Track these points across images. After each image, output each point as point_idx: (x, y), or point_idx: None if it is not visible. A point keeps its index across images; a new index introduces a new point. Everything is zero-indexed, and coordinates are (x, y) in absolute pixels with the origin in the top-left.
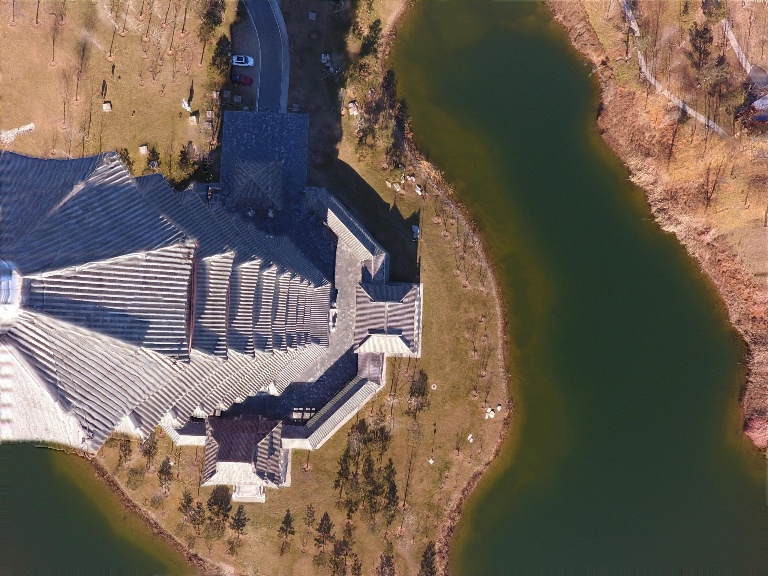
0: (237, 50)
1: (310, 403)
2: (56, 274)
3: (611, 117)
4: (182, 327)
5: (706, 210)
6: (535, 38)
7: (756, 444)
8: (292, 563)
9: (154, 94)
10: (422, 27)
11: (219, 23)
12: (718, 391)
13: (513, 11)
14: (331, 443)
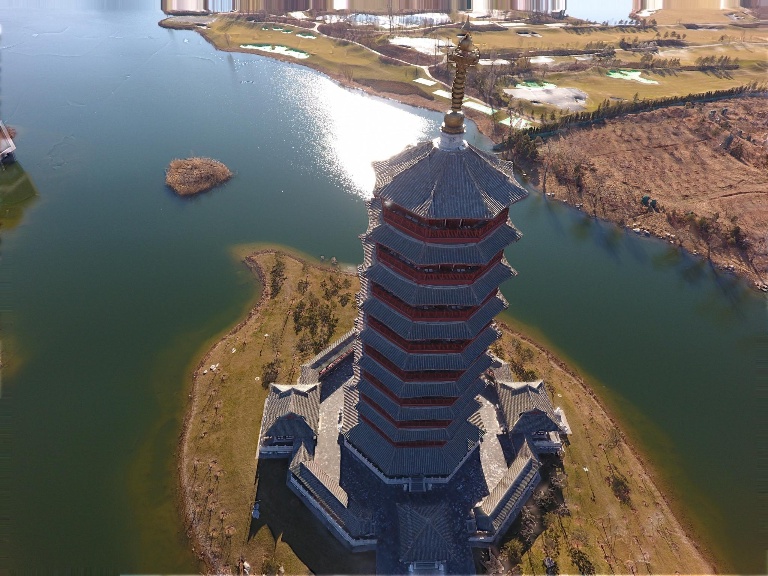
0: None
1: None
2: None
3: None
4: None
5: None
6: None
7: None
8: None
9: None
10: None
11: None
12: None
13: None
14: None
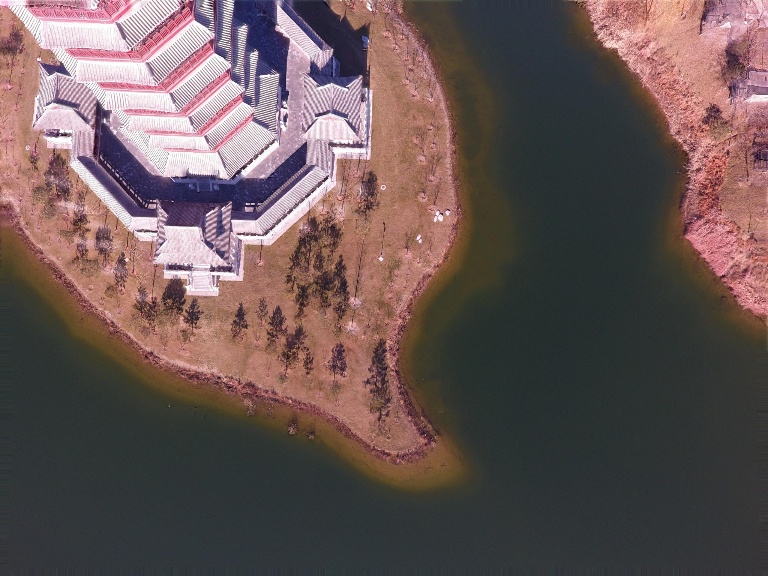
0: None
1: (262, 198)
2: None
3: None
4: None
5: (645, 24)
6: None
7: (696, 247)
8: (246, 358)
9: None
10: None
11: None
12: (660, 202)
13: None
14: (283, 240)
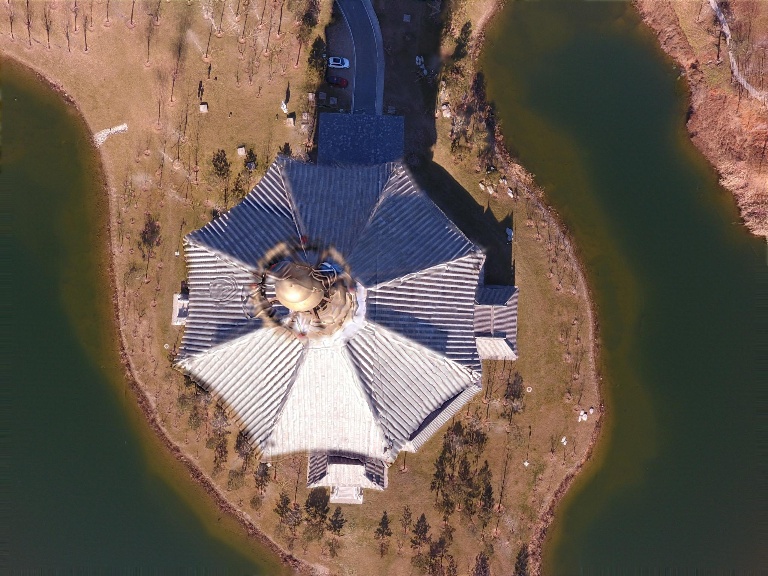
0: (332, 52)
1: None
2: (383, 285)
3: (701, 121)
4: (472, 337)
5: None
6: (623, 41)
7: None
8: (387, 564)
9: (251, 95)
10: (510, 29)
11: (314, 25)
12: None
13: (601, 14)
14: (427, 445)
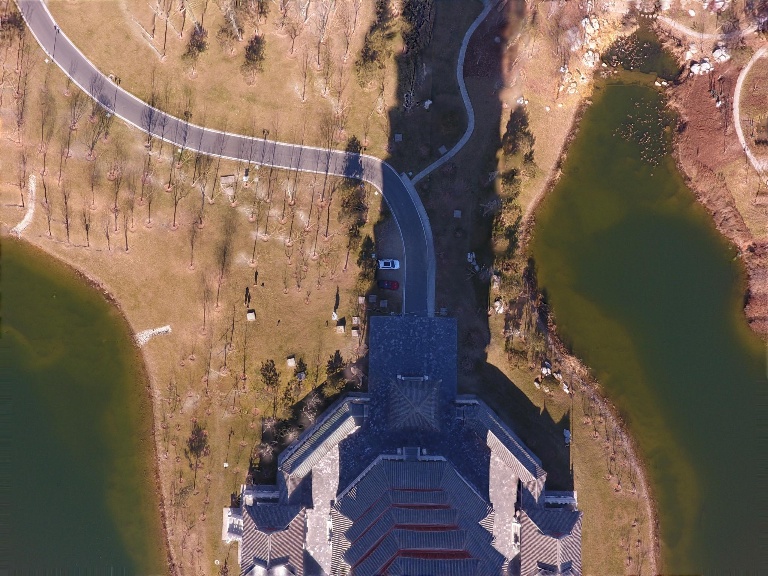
0: (381, 251)
1: None
2: None
3: (759, 305)
4: None
5: None
6: (676, 219)
7: None
8: None
9: (299, 302)
10: (560, 210)
11: (363, 224)
12: None
13: (653, 191)
14: None
